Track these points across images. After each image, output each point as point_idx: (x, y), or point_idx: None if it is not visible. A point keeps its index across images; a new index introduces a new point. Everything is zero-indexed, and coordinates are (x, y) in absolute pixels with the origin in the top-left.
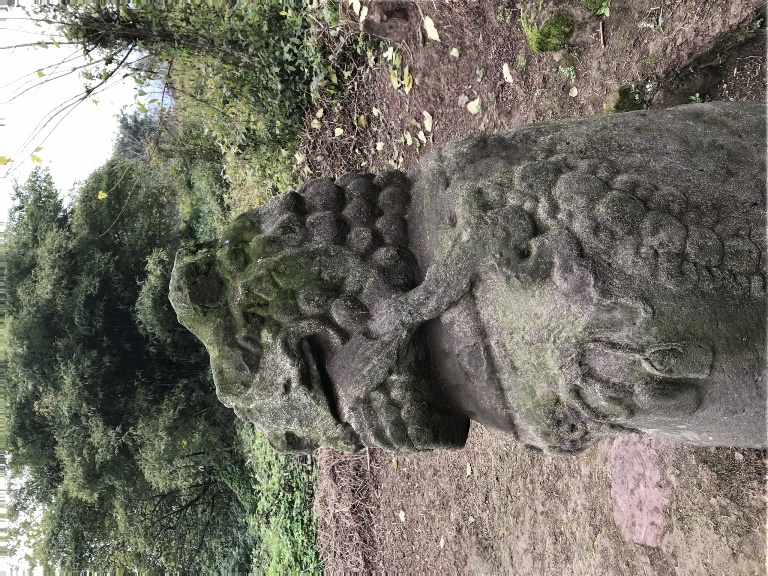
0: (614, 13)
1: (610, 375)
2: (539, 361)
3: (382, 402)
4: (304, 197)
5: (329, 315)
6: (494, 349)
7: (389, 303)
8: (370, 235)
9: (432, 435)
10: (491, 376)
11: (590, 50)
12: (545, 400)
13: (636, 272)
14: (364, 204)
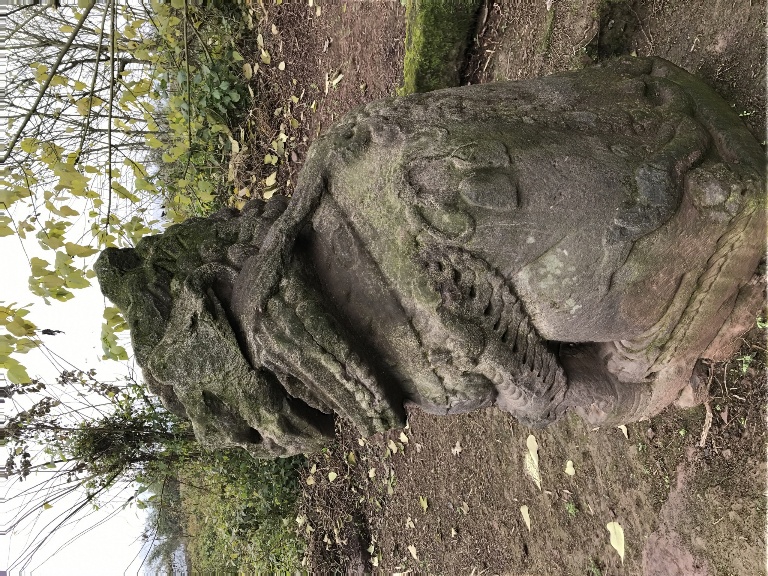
0: None
1: (437, 186)
2: (386, 207)
3: (278, 308)
4: None
5: (227, 261)
6: (355, 223)
7: None
8: (256, 209)
9: (327, 322)
10: (361, 249)
11: None
12: (406, 245)
13: (428, 117)
14: None
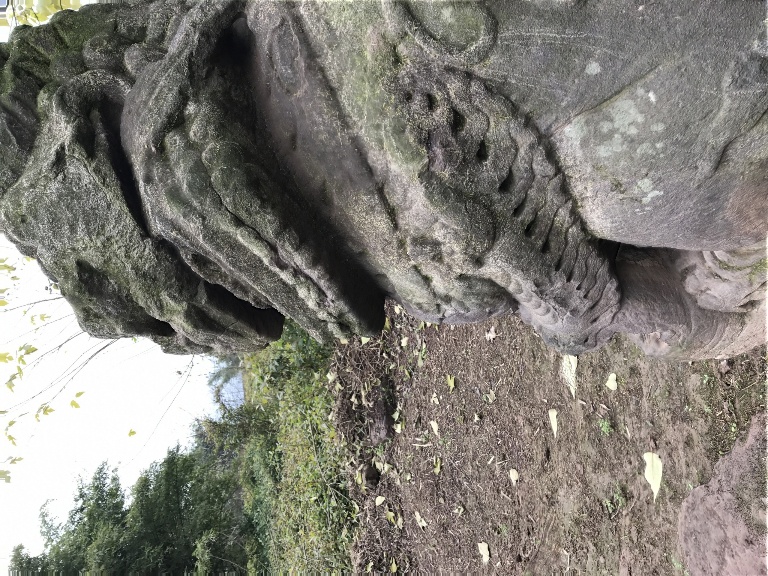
0: None
1: None
2: None
3: (178, 149)
4: None
5: (124, 70)
6: (304, 17)
7: None
8: None
9: (244, 177)
10: (309, 63)
11: None
12: (379, 61)
13: None
14: None
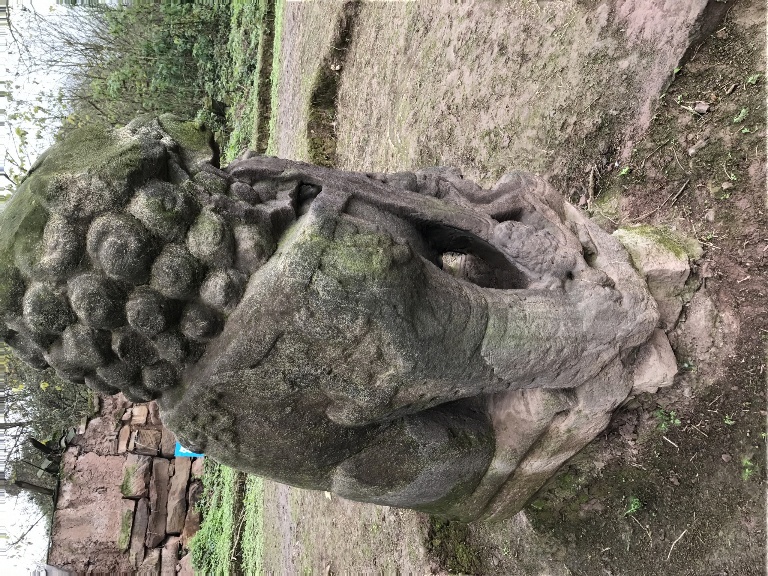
0: None
1: None
2: None
3: None
4: None
5: None
6: None
7: None
8: None
9: None
10: None
11: None
12: None
13: None
14: None
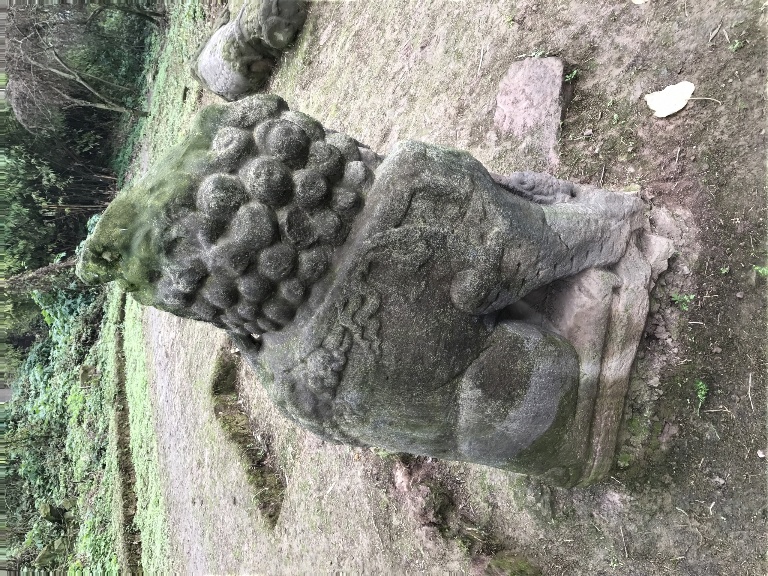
0: None
1: None
2: None
3: None
4: (203, 287)
5: None
6: None
7: (228, 332)
8: None
9: None
10: None
11: None
12: None
13: None
14: (240, 323)
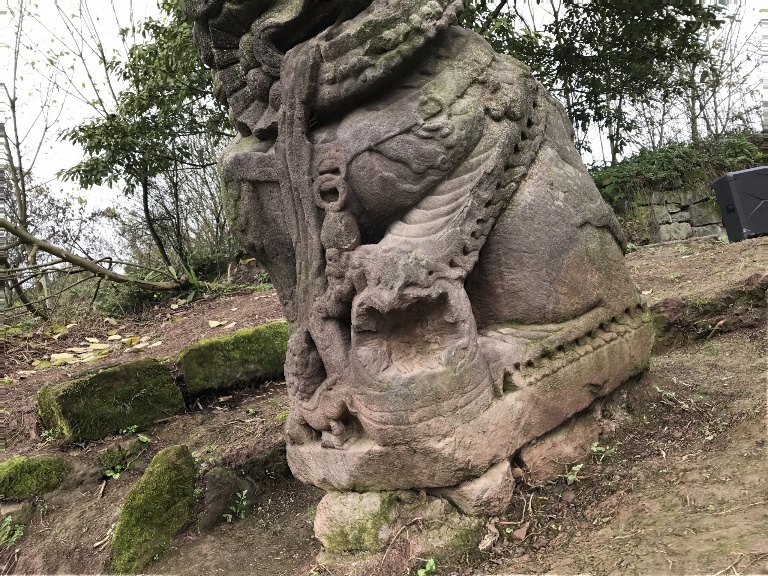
0: (126, 476)
1: None
2: None
3: None
4: None
5: None
6: None
7: None
8: None
9: None
10: None
11: (70, 506)
12: None
13: None
14: None
